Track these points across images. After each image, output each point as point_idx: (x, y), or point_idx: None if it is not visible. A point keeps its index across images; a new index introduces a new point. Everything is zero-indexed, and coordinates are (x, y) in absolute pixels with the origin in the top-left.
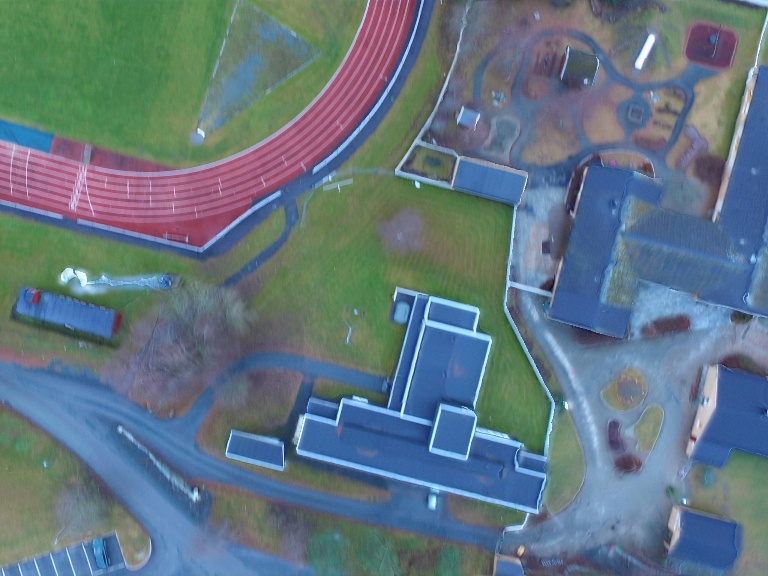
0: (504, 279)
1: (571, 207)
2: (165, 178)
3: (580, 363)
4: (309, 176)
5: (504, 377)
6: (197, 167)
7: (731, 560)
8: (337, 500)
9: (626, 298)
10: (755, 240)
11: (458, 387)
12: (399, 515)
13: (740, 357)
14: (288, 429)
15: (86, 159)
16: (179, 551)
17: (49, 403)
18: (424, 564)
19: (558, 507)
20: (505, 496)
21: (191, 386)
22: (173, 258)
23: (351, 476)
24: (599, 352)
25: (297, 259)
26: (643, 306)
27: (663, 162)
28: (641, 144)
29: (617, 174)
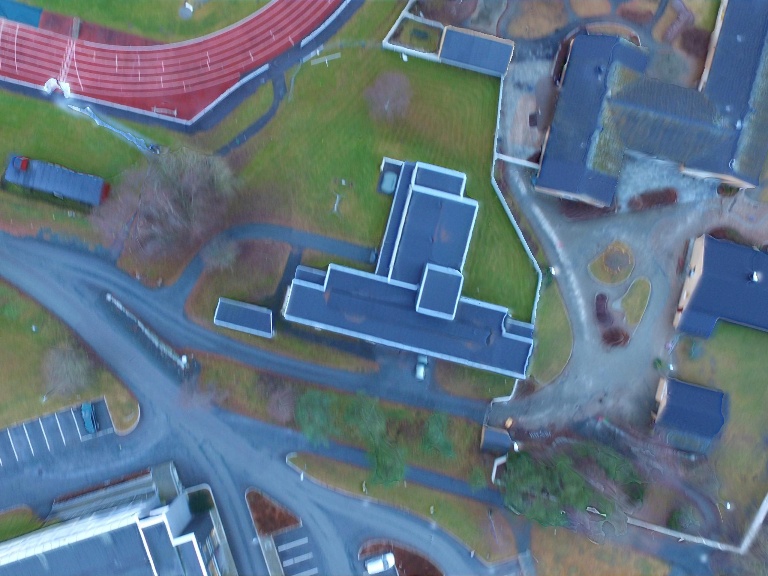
0: (491, 151)
1: (558, 77)
2: (153, 52)
3: (567, 236)
4: (297, 50)
5: (492, 249)
6: (185, 41)
7: (718, 428)
8: (325, 370)
9: (612, 166)
10: (741, 106)
11: (445, 253)
12: (387, 386)
13: (727, 230)
14: (276, 300)
15: (75, 33)
16: (168, 417)
17: (38, 271)
18: (412, 433)
19: (546, 380)
20: (492, 362)
21: (179, 251)
22: (162, 132)
23: (339, 347)
24: (586, 225)
25: (285, 132)
26: (630, 179)
27: (649, 35)
28: (628, 17)
29: (603, 41)
